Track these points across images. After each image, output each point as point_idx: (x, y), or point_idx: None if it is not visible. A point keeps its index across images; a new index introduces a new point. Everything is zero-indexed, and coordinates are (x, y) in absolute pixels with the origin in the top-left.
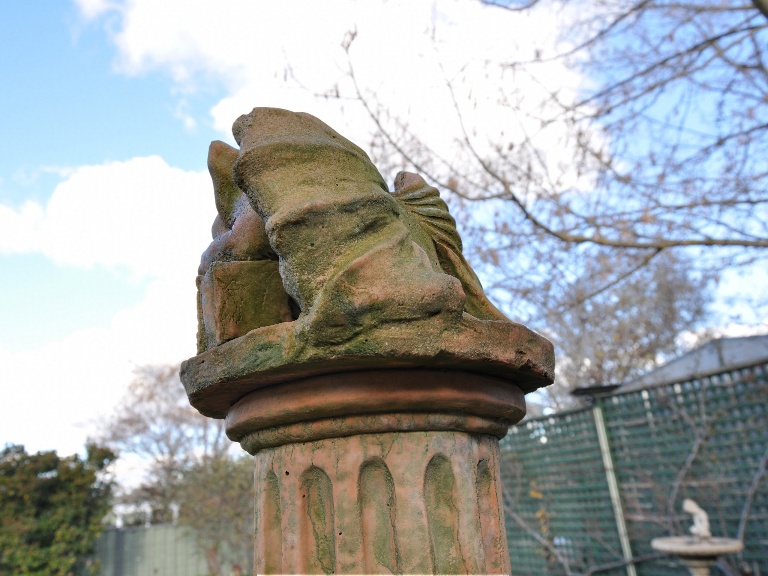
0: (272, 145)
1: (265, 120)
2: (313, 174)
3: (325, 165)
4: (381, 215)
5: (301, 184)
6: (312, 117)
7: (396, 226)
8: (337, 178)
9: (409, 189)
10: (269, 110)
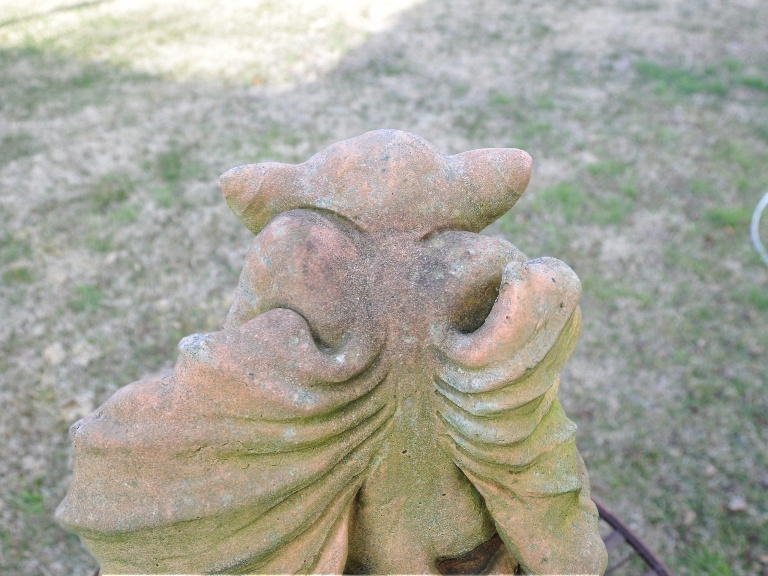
0: (72, 525)
1: (83, 459)
2: (125, 554)
3: (140, 545)
4: (239, 570)
5: (114, 560)
6: (202, 368)
7: (272, 570)
8: (157, 558)
9: (459, 361)
10: (86, 445)
